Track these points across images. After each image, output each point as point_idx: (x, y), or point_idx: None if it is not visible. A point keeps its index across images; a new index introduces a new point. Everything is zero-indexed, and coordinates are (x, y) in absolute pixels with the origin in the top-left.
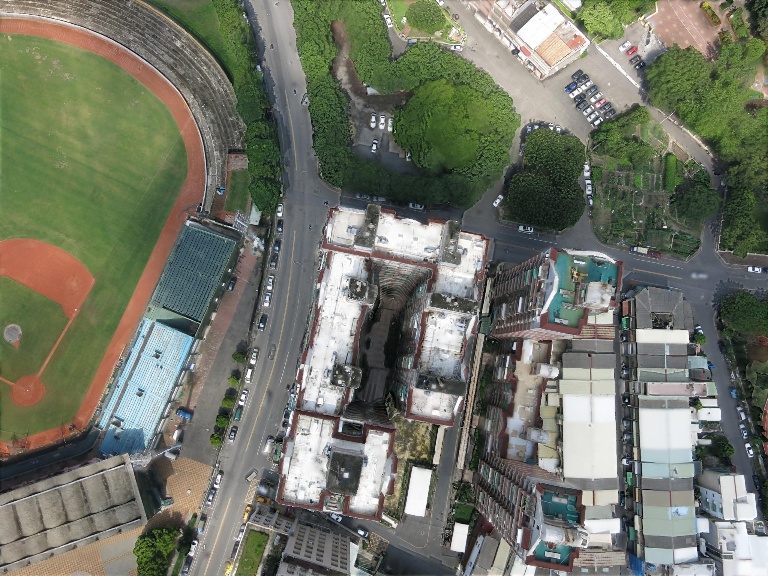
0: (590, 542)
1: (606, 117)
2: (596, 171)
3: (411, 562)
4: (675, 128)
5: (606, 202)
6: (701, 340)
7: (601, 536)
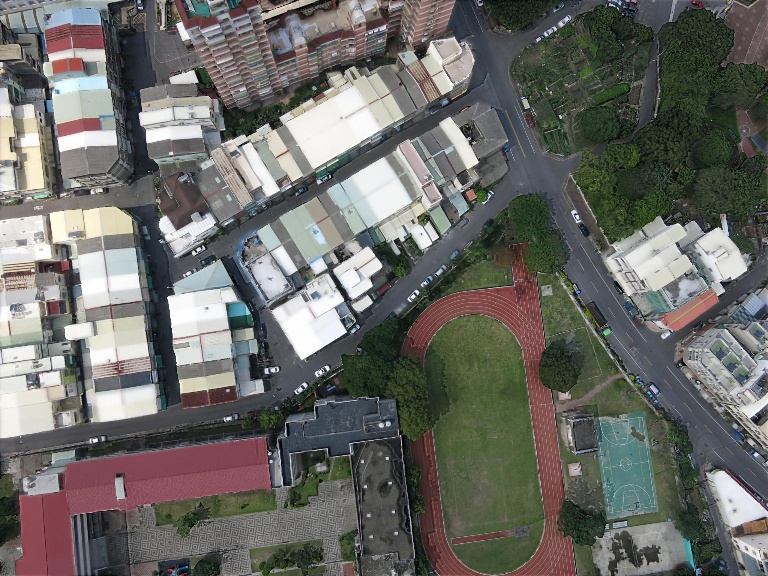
0: (244, 171)
1: (622, 14)
2: (568, 28)
3: (141, 58)
4: (654, 78)
5: (548, 55)
6: (481, 193)
7: (255, 177)
